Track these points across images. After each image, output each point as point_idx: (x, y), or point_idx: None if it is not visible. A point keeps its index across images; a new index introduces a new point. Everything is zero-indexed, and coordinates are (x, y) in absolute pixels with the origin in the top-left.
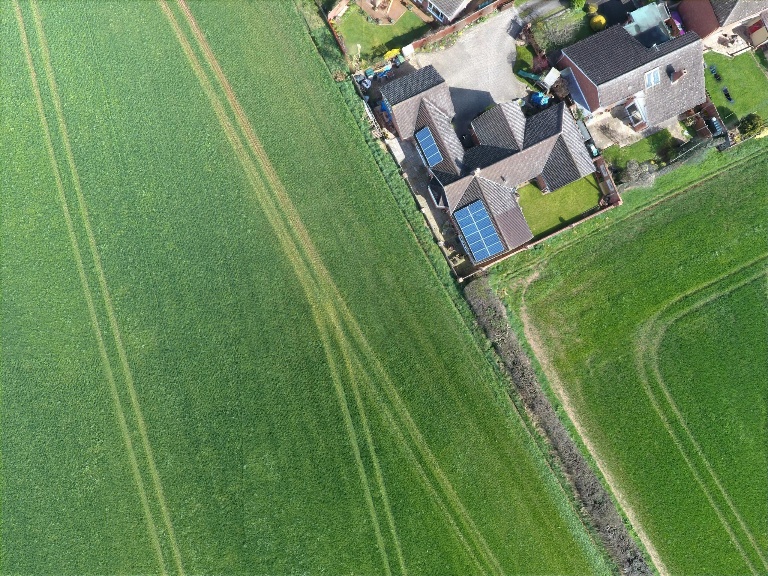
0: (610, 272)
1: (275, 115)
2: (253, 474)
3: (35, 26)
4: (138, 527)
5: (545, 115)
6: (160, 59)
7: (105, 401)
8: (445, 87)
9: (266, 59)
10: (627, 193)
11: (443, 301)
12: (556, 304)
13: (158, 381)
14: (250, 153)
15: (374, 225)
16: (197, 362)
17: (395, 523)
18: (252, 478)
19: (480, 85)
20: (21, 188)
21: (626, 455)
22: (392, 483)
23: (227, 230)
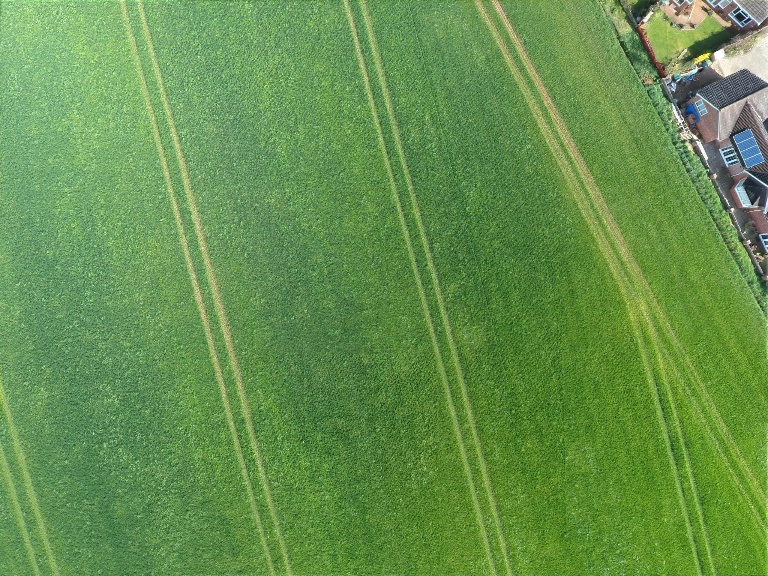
0: None
1: (588, 118)
2: (574, 466)
3: (367, 31)
4: (468, 517)
5: None
6: (482, 63)
7: (439, 395)
8: None
9: (578, 63)
10: None
11: (748, 298)
12: None
13: (487, 375)
14: (566, 154)
15: (682, 224)
16: (523, 357)
17: (703, 513)
18: (573, 470)
19: None
20: (359, 188)
21: None
22: (701, 475)
23: (548, 229)
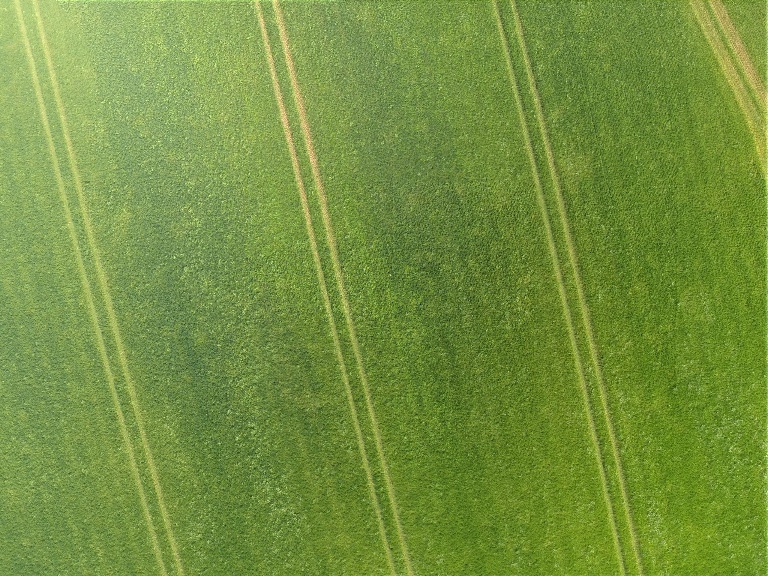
0: None
1: None
2: (686, 313)
3: None
4: (565, 363)
5: None
6: None
7: (538, 229)
8: None
9: None
10: None
11: None
12: None
13: (593, 210)
14: None
15: None
16: (633, 191)
17: None
18: (685, 317)
19: None
20: (457, 6)
21: None
22: None
23: (666, 52)
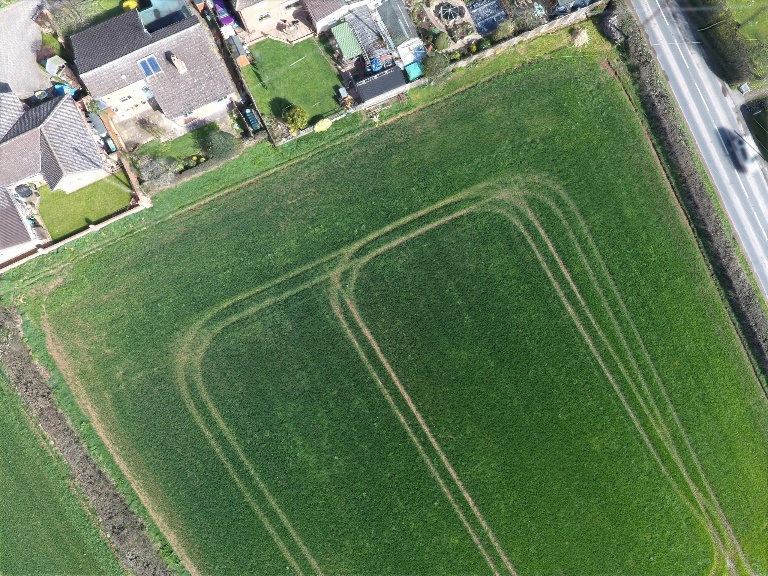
0: (145, 277)
1: None
2: None
3: None
4: None
5: (42, 107)
6: None
7: None
8: None
9: None
10: (167, 191)
11: None
12: (82, 312)
13: None
14: None
15: None
16: None
17: None
18: None
19: None
20: None
21: (164, 475)
22: None
23: None
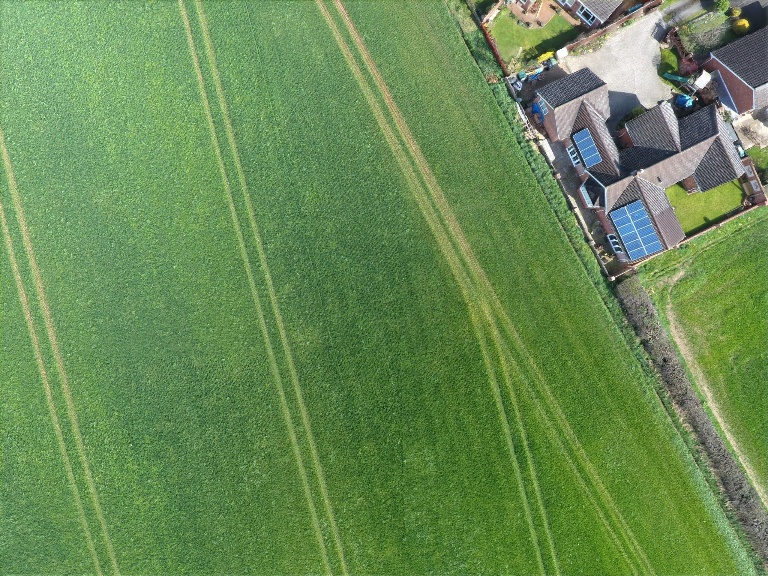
0: (752, 271)
1: (431, 117)
2: (412, 469)
3: (201, 29)
4: (303, 520)
5: (698, 117)
6: (321, 62)
7: (272, 397)
8: (605, 89)
9: (421, 62)
10: None
11: (594, 299)
12: (701, 302)
13: (322, 377)
14: (407, 154)
15: (527, 225)
16: (359, 359)
17: (547, 517)
18: (411, 473)
19: (627, 87)
20: (190, 188)
21: (767, 450)
22: (545, 478)
23: (387, 229)
